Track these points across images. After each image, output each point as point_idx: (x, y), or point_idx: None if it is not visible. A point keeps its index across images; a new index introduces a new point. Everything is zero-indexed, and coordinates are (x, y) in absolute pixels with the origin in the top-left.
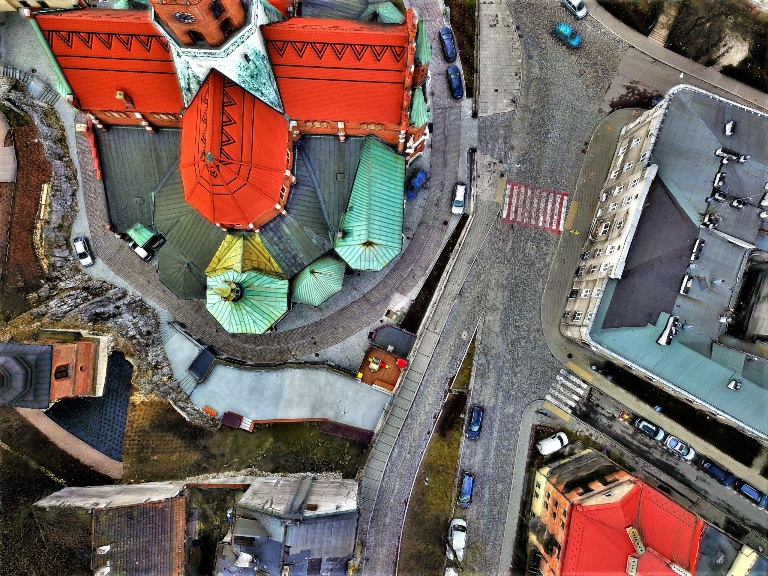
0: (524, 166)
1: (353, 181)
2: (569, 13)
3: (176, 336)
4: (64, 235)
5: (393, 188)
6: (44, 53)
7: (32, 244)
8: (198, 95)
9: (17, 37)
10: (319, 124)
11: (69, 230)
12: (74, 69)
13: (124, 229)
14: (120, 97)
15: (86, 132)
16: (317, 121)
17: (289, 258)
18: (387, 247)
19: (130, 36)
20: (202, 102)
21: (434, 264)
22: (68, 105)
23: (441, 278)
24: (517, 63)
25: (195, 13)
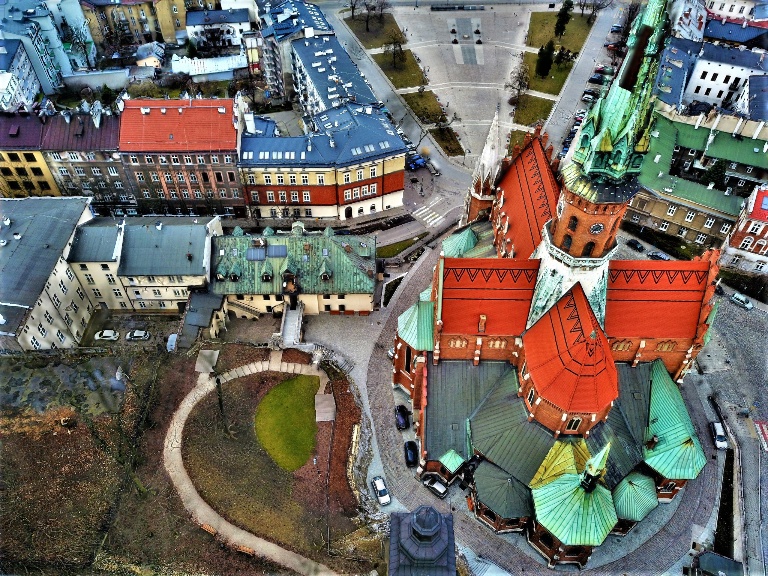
0: (762, 409)
1: (649, 399)
2: (738, 307)
3: (491, 569)
4: (362, 475)
5: (682, 406)
6: (339, 339)
7: (346, 475)
8: (549, 312)
9: (318, 330)
10: (622, 346)
11: (366, 472)
12: (451, 299)
13: (436, 456)
14: (483, 318)
15: (423, 364)
16: (625, 341)
17: (609, 467)
18: (699, 453)
19: (506, 270)
20: (563, 310)
21: (720, 495)
22: (360, 373)
23: (734, 507)
24: (716, 338)
25: (607, 223)
